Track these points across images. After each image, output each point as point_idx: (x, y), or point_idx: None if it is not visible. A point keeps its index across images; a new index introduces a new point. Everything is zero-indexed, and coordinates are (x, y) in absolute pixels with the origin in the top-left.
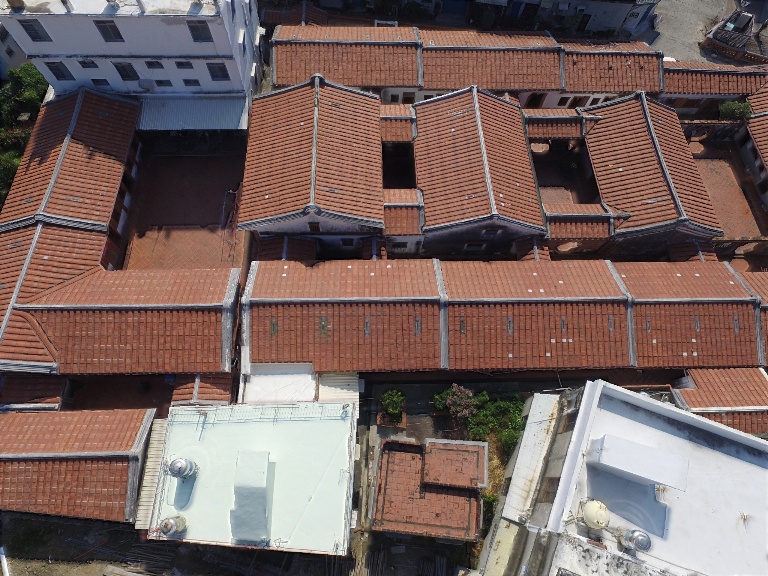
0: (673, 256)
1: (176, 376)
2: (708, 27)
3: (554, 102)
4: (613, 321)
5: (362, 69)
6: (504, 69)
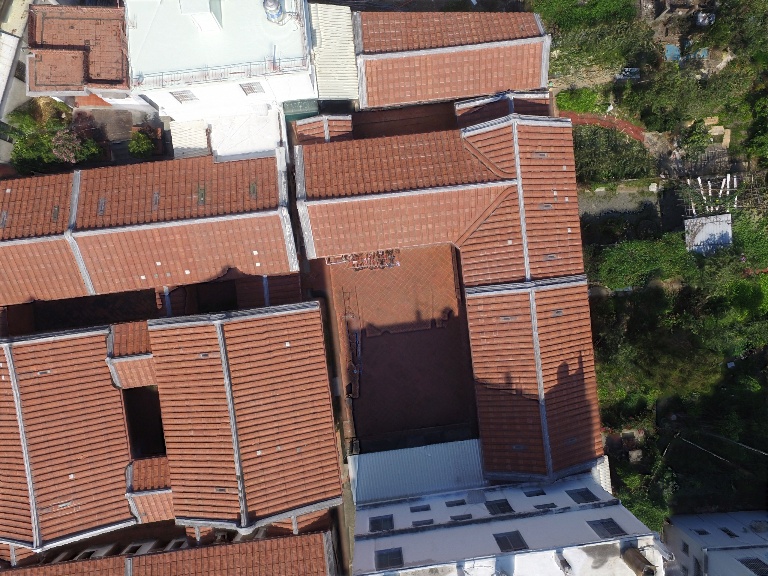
0: None
1: None
2: None
3: None
4: None
5: (208, 573)
6: None
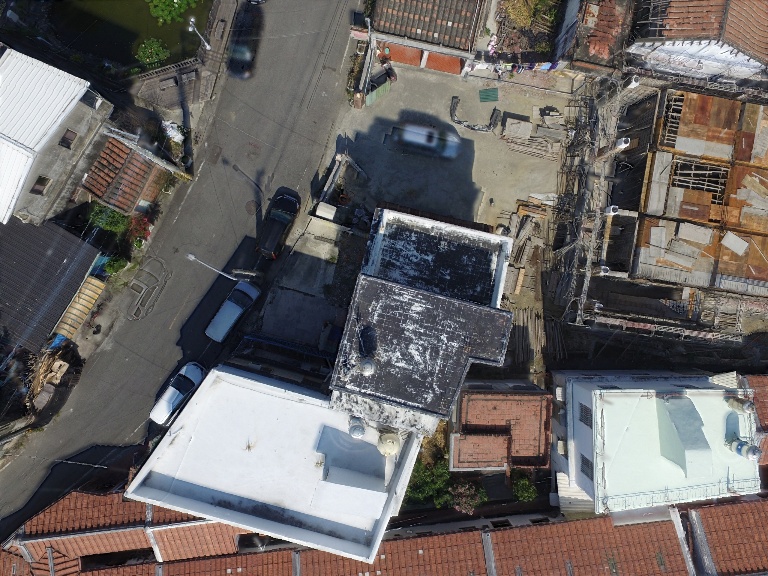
0: None
1: None
2: None
3: None
4: None
5: None
6: None
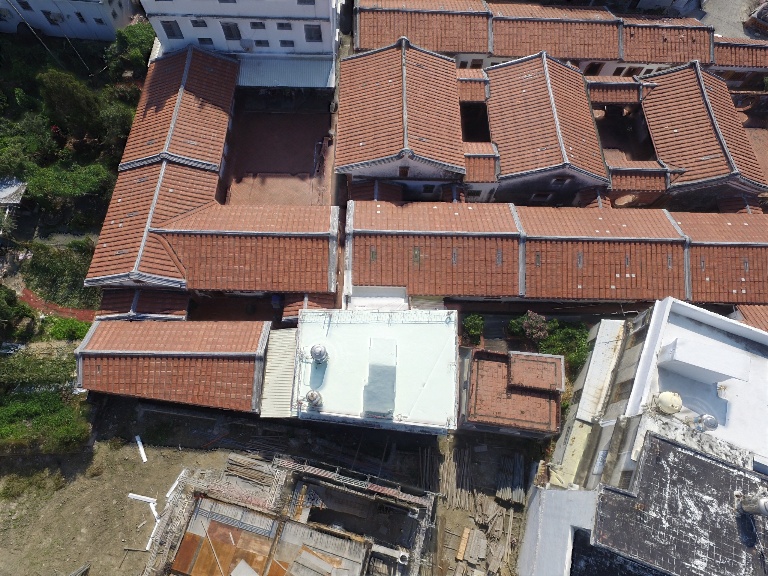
0: (722, 209)
1: (285, 296)
2: (752, 8)
3: (610, 72)
4: (672, 260)
5: (437, 36)
6: (567, 39)
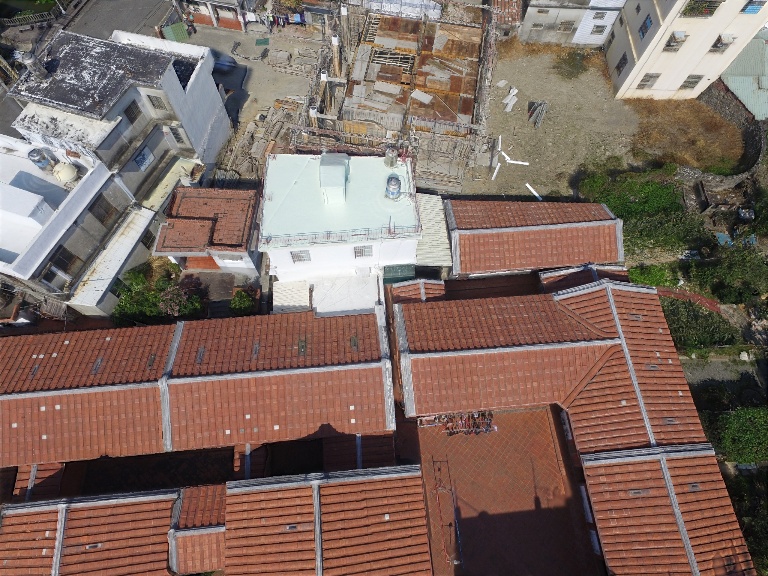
0: None
1: None
2: None
3: None
4: None
5: None
6: None
